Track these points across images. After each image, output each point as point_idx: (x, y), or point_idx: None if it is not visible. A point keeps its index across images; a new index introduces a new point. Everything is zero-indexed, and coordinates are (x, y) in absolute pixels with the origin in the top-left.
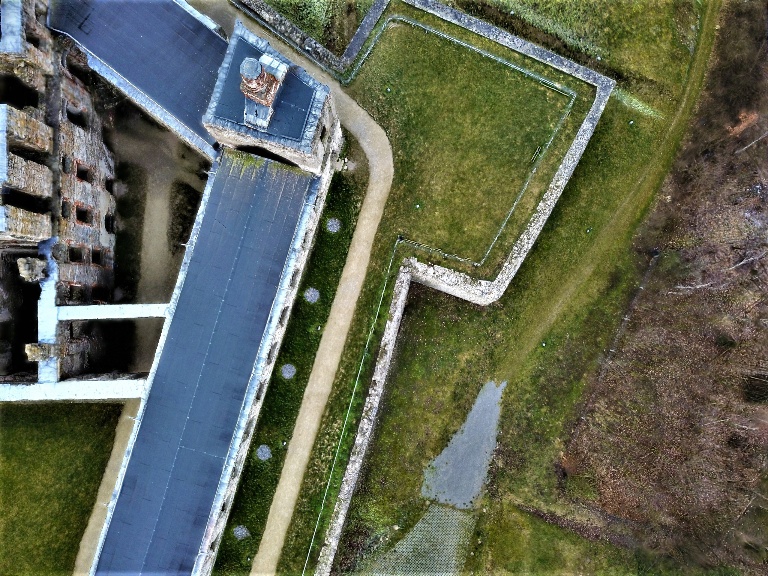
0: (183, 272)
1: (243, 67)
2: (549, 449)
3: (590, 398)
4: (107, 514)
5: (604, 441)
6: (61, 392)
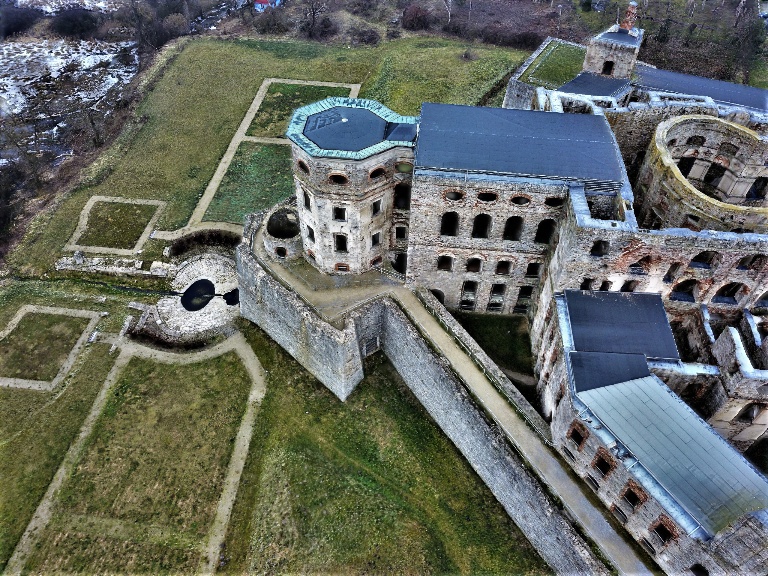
0: (693, 100)
1: (634, 4)
2: None
3: (683, 72)
4: None
5: None
6: None
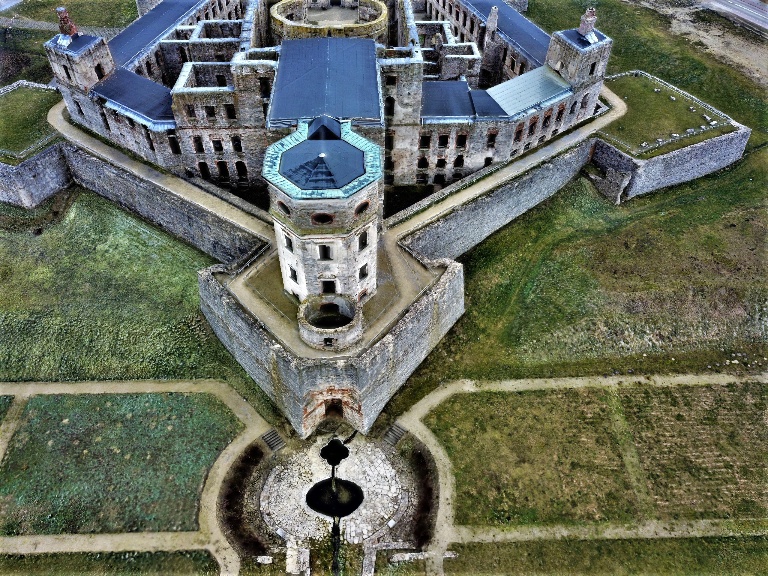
0: (150, 48)
1: None
2: (29, 69)
3: None
4: (201, 7)
5: (1, 71)
6: None
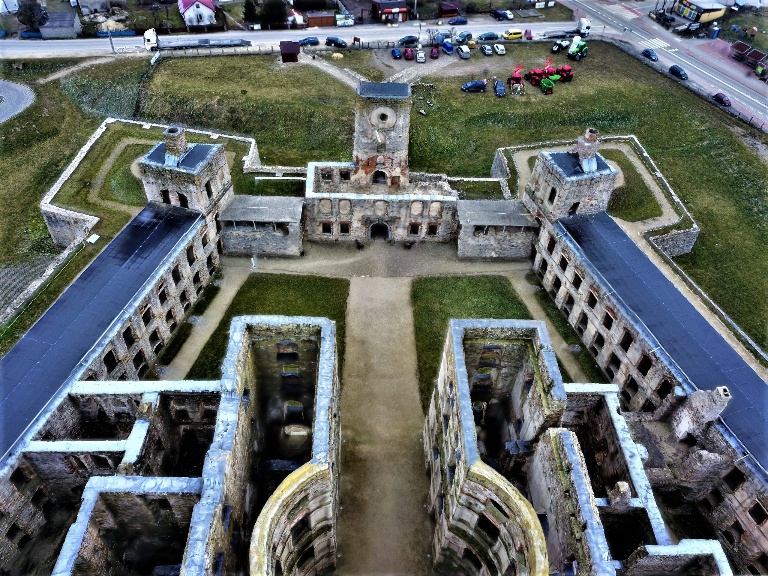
0: None
1: None
2: None
3: None
4: (134, 311)
5: None
6: (141, 386)
